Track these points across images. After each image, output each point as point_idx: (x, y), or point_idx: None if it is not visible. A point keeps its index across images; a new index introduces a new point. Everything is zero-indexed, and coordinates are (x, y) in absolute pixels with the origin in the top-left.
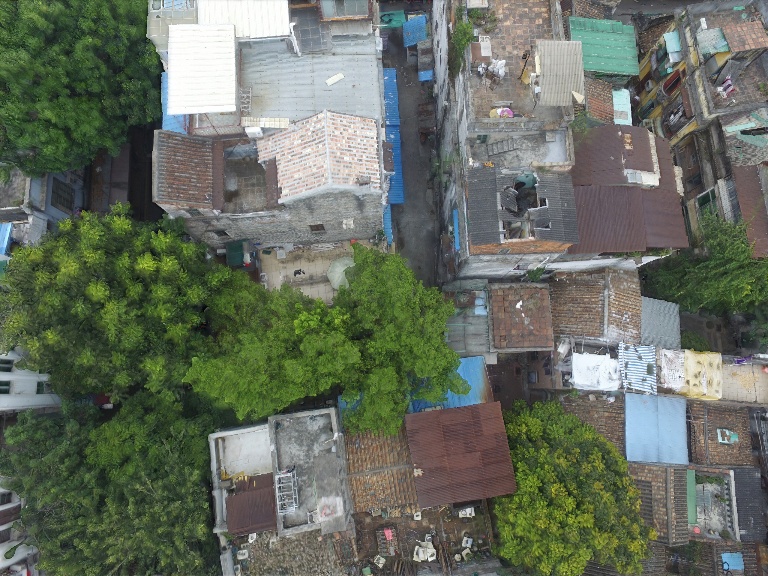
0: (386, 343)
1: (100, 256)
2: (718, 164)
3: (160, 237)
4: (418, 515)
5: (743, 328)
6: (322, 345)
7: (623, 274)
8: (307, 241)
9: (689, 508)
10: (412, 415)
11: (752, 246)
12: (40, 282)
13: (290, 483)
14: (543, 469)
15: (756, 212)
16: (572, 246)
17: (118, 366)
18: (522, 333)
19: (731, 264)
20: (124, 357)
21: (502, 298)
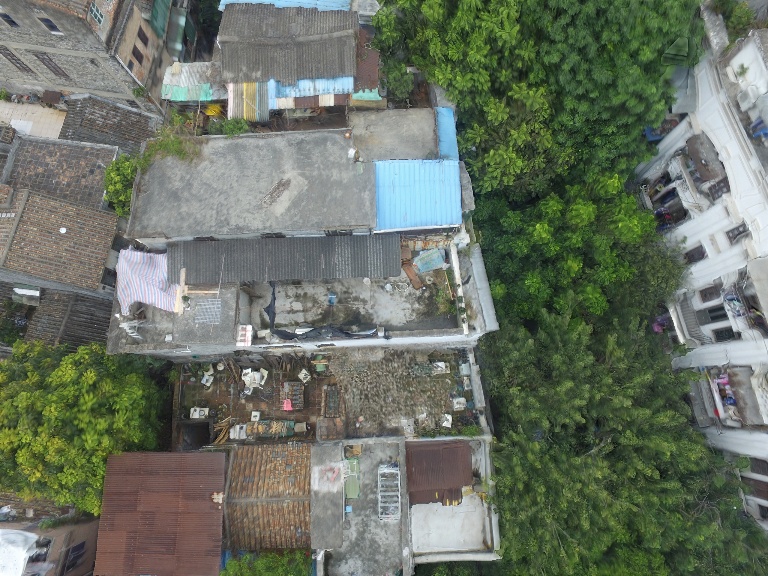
0: None
1: None
2: None
3: None
4: (255, 417)
5: None
6: None
7: None
8: None
9: None
10: None
11: None
12: None
13: None
14: None
15: None
16: None
17: None
18: None
19: None
20: None
21: None
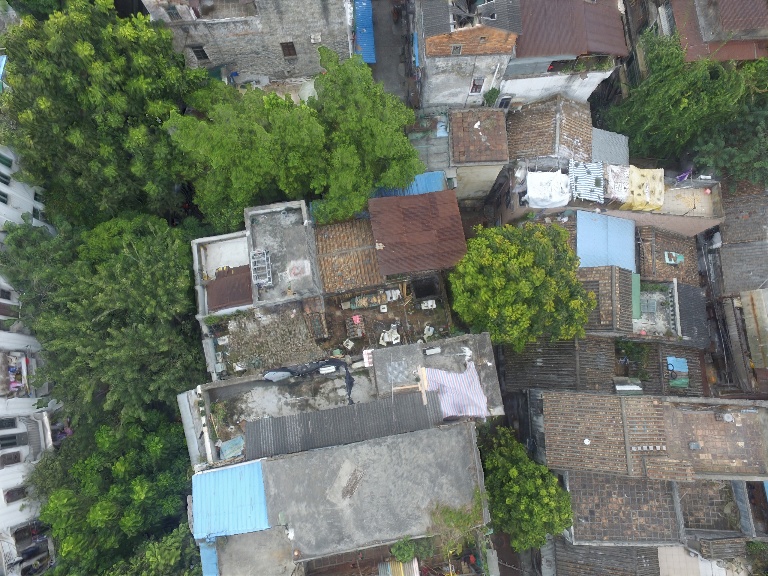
0: (348, 123)
1: (86, 21)
2: (662, 2)
3: (141, 19)
4: (384, 308)
5: (694, 178)
6: (289, 117)
7: (575, 104)
8: (281, 73)
9: (634, 305)
10: (374, 199)
11: (685, 51)
12: (33, 57)
13: (264, 258)
14: (492, 238)
15: (689, 23)
16: (520, 51)
17: (106, 159)
18: (479, 149)
19: (667, 71)
20: (111, 150)
21: (461, 120)
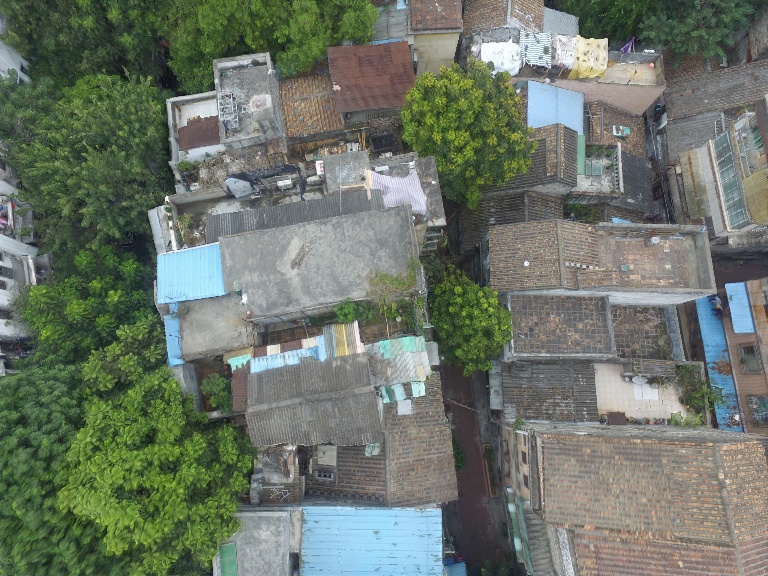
0: None
1: None
2: None
3: None
4: None
5: None
6: None
7: None
8: None
9: (579, 163)
10: (333, 48)
11: None
12: None
13: (230, 99)
14: None
15: None
16: None
17: (84, 11)
18: (435, 18)
19: None
20: (89, 1)
21: None
